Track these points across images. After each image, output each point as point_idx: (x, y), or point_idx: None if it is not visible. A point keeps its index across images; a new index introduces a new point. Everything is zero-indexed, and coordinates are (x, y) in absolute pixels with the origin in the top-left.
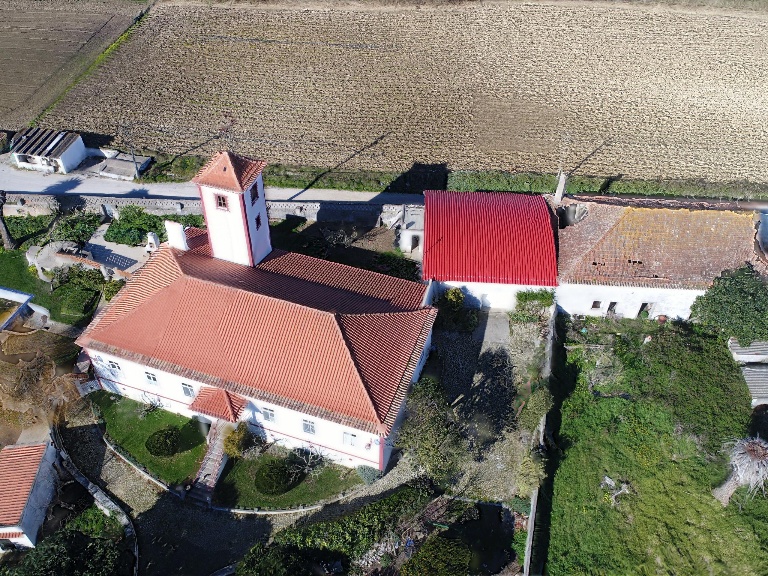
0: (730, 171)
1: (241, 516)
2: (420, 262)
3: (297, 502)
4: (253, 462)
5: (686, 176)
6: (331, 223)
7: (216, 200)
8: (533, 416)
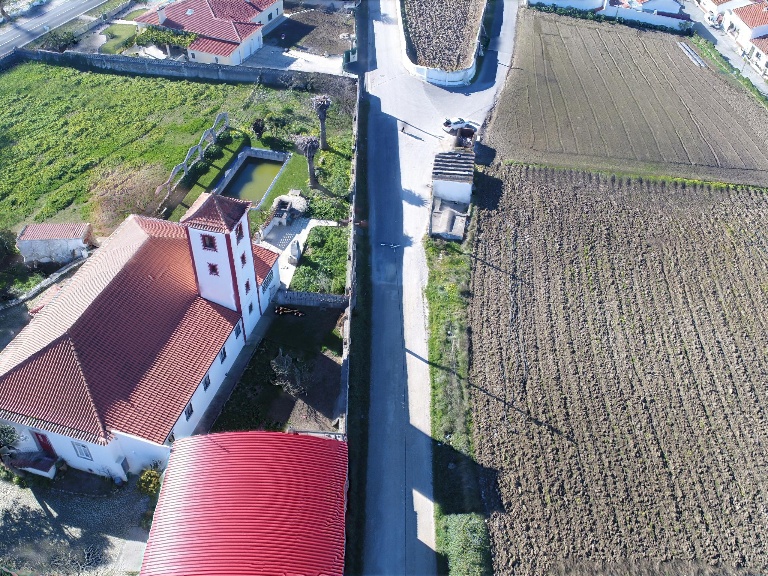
0: None
1: None
2: None
3: None
4: None
5: None
6: (339, 378)
7: None
8: None
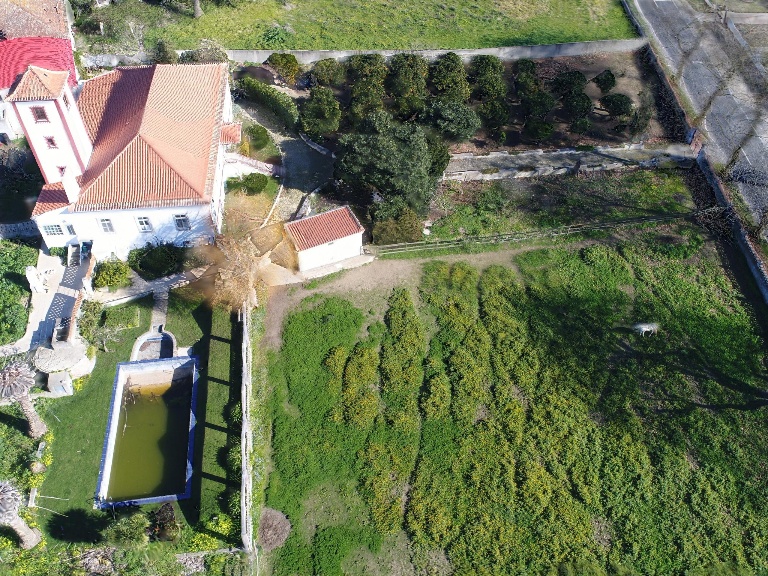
0: None
1: (284, 154)
2: None
3: None
4: None
5: None
6: None
7: None
8: None
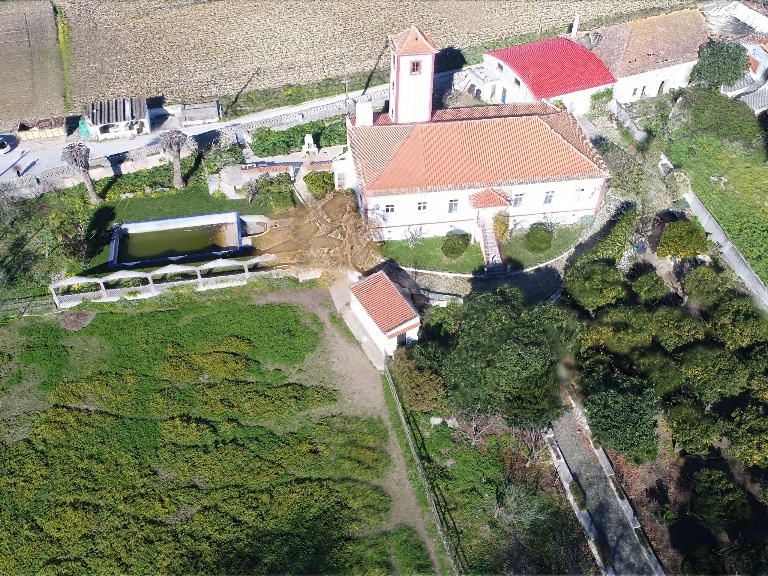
0: (632, 6)
1: (532, 272)
2: (503, 104)
3: (559, 251)
4: (510, 243)
5: (609, 15)
6: None
7: (411, 67)
8: (656, 156)
